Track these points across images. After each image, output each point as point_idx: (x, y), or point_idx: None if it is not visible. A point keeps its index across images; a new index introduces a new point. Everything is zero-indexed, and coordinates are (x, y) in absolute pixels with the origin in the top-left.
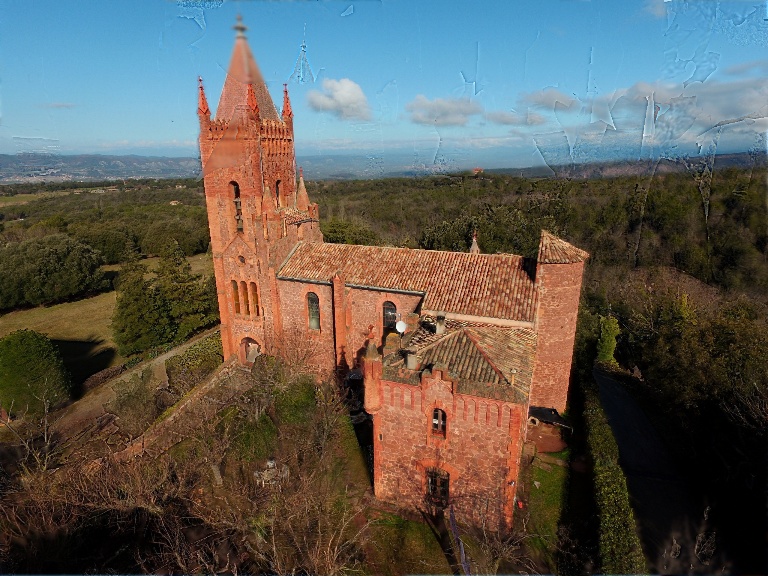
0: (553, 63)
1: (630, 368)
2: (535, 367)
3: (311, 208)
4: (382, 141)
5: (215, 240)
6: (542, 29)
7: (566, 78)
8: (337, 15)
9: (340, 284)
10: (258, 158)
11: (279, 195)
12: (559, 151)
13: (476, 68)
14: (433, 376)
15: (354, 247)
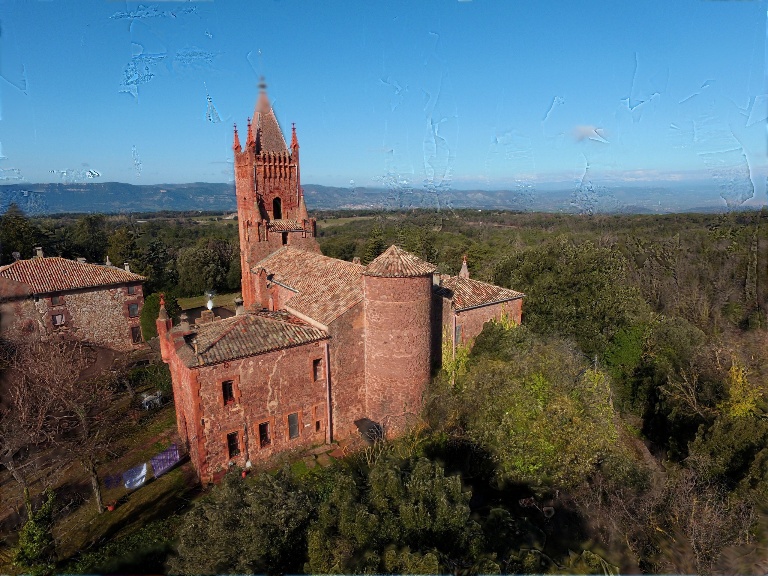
0: (706, 65)
1: (658, 453)
2: (368, 379)
3: (303, 221)
4: (534, 168)
5: (241, 241)
6: (690, 27)
7: (720, 81)
8: (229, 73)
9: (259, 278)
10: (252, 180)
11: (281, 209)
12: (738, 174)
13: (632, 82)
14: (171, 337)
15: (305, 253)
